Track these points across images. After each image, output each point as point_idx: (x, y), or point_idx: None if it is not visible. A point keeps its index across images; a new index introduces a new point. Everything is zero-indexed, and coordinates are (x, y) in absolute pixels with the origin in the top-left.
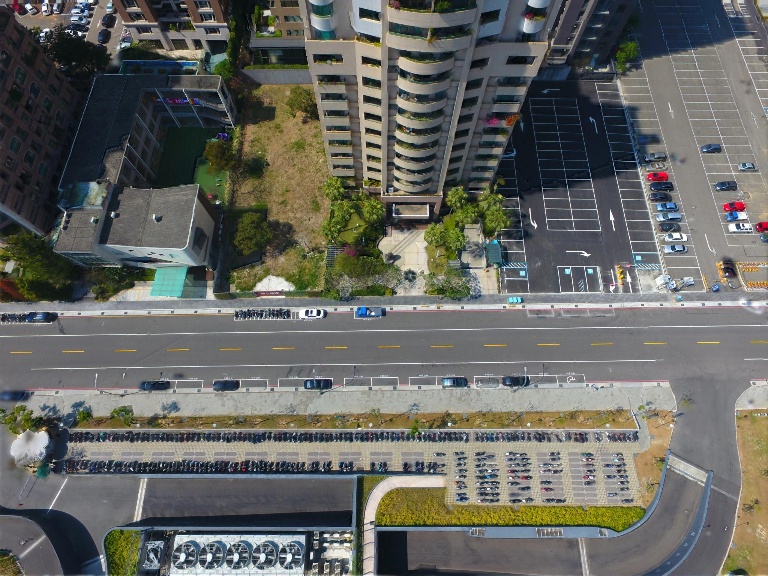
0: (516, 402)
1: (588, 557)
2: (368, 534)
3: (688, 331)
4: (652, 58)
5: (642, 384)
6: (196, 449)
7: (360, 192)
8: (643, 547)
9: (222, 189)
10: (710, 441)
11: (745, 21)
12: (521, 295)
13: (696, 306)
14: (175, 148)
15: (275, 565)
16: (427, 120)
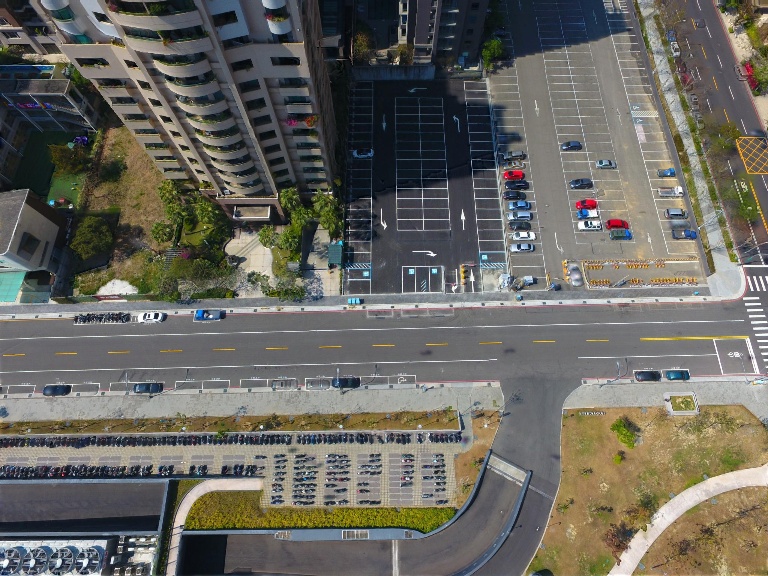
0: (344, 404)
1: (399, 559)
2: (176, 538)
3: (525, 330)
4: (525, 56)
5: (472, 384)
6: (20, 454)
7: (196, 195)
8: (455, 548)
9: (76, 193)
10: (533, 441)
11: (623, 17)
12: (362, 296)
13: (536, 305)
14: (36, 152)
15: (73, 570)
16: (213, 122)
